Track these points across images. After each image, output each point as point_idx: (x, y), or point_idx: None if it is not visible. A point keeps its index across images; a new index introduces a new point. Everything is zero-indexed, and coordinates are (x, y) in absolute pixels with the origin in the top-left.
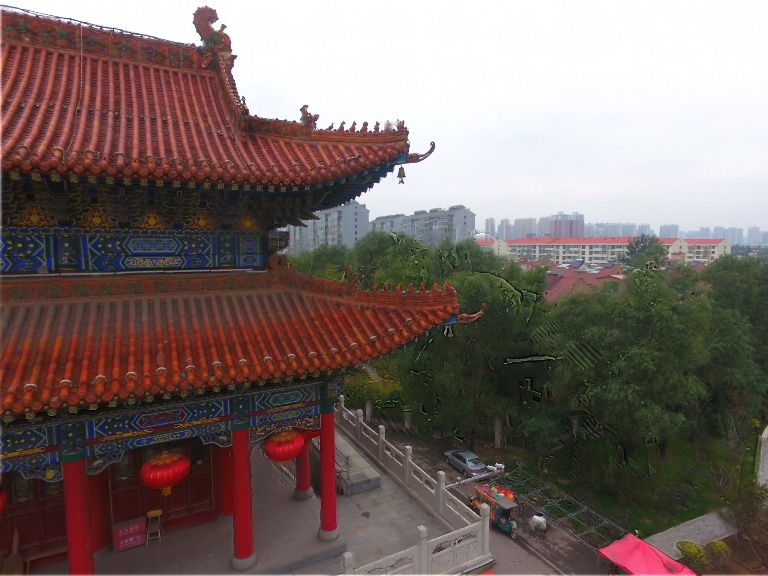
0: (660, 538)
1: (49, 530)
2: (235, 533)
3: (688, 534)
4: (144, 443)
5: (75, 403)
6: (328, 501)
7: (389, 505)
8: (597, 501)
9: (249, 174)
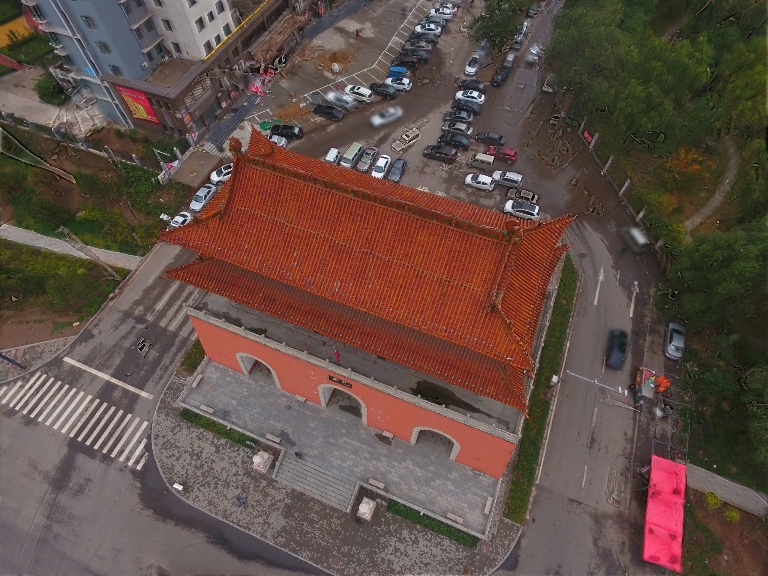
0: (721, 481)
1: None
2: None
3: (745, 497)
4: None
5: None
6: None
7: None
8: (724, 435)
9: (470, 348)
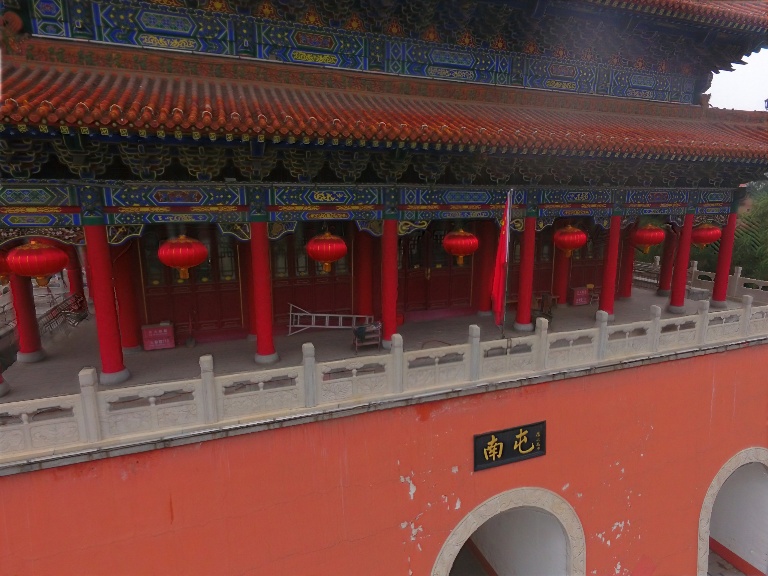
0: None
1: (541, 284)
2: (674, 289)
3: None
4: (647, 213)
5: (692, 153)
6: (725, 279)
7: (731, 305)
8: None
9: (754, 16)
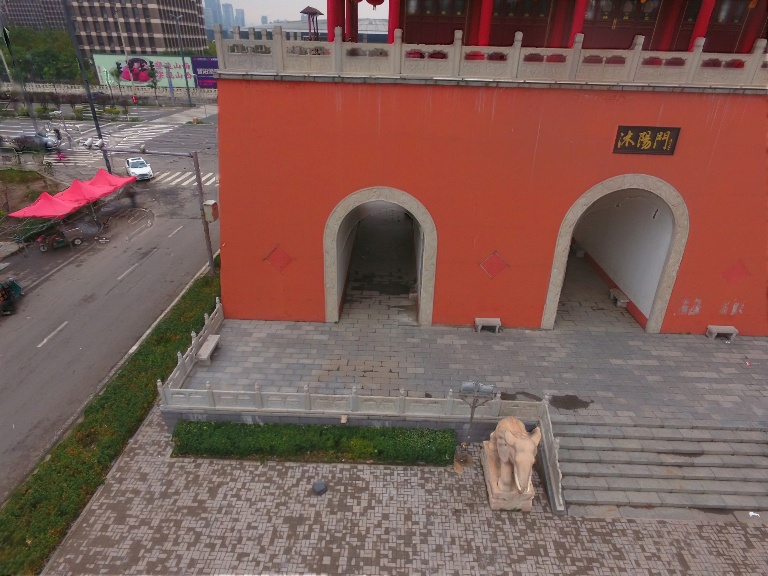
0: None
1: None
2: None
3: None
4: None
5: None
6: None
7: None
8: None
9: None
